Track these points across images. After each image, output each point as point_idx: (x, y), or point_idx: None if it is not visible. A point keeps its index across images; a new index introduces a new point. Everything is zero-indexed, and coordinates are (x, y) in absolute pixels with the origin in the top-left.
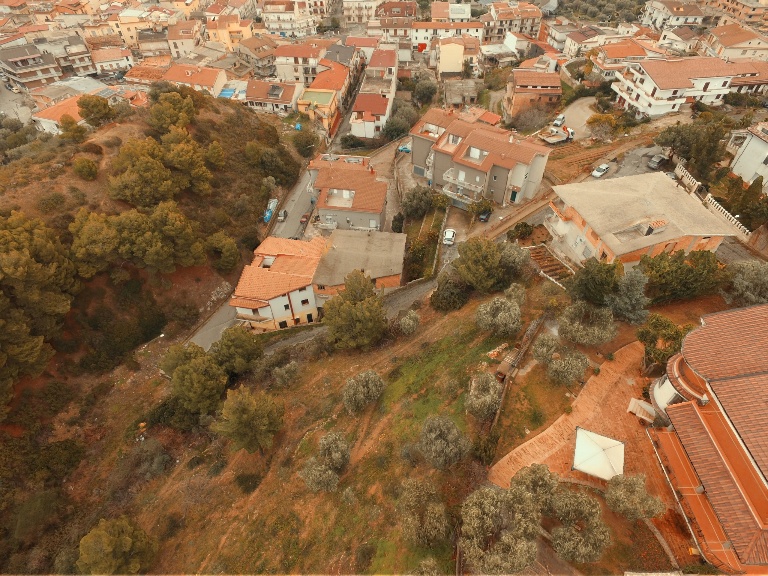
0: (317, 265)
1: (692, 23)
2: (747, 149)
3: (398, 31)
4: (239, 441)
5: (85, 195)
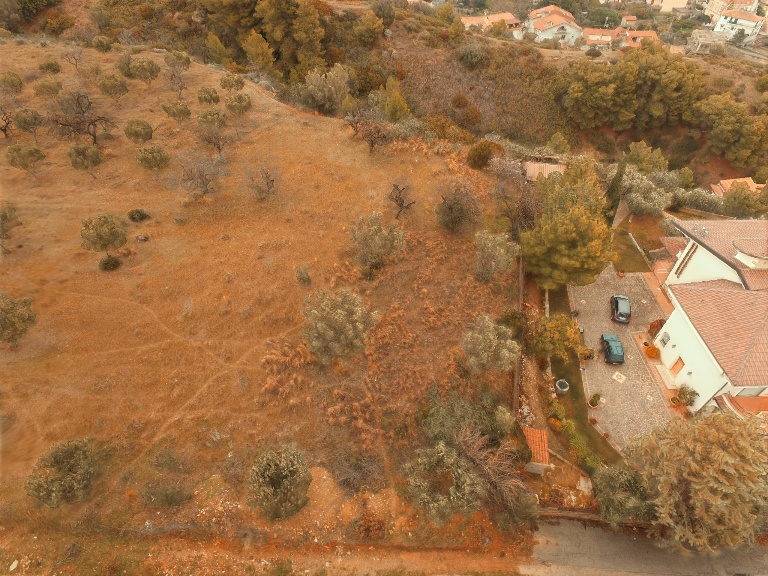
0: None
1: None
2: None
3: None
4: None
5: (743, 92)
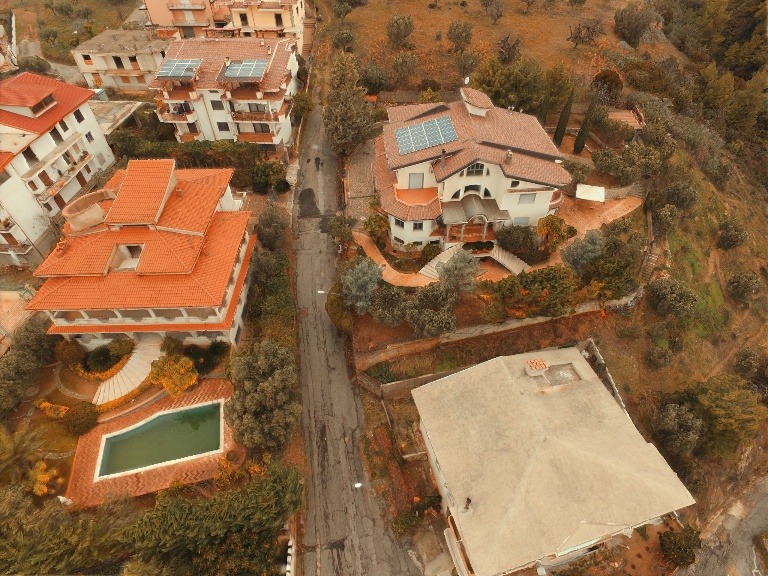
0: None
1: None
2: None
3: None
4: None
5: None
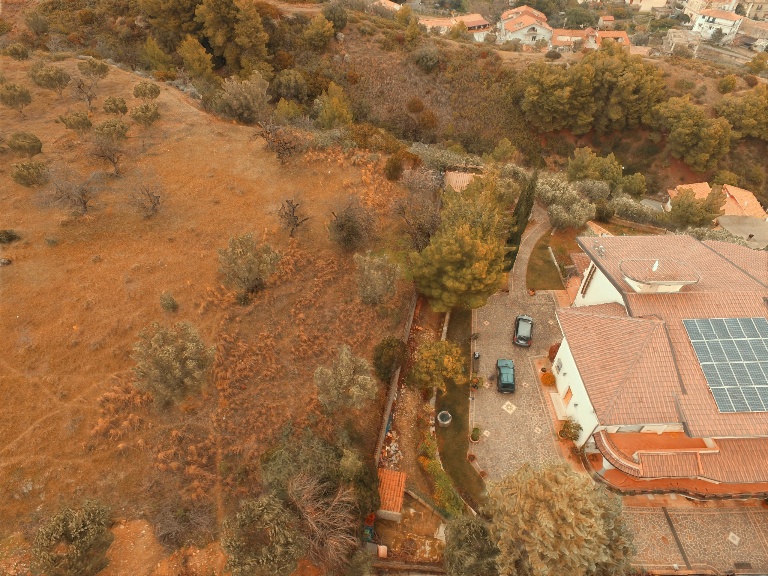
0: (738, 215)
1: None
2: None
3: None
4: (567, 176)
5: (704, 94)
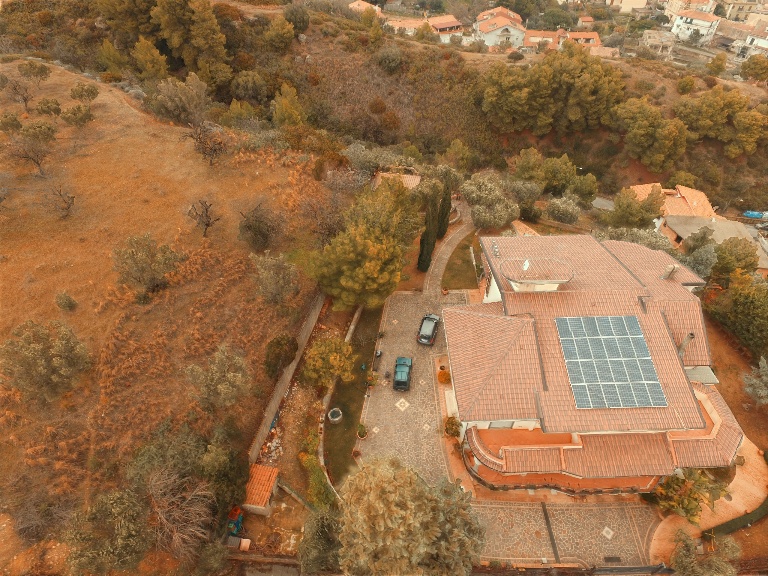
0: (686, 215)
1: None
2: None
3: None
4: (515, 177)
5: (664, 95)
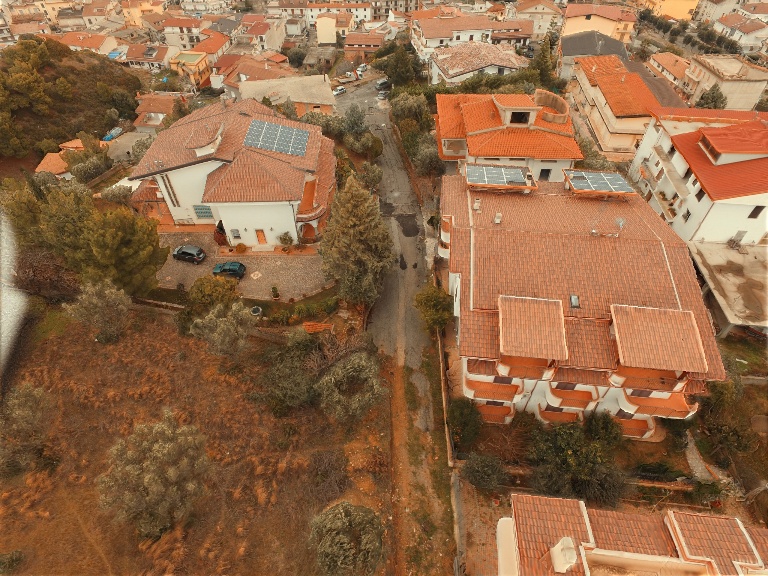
0: None
1: (559, 4)
2: (433, 70)
3: (295, 10)
4: None
5: None
